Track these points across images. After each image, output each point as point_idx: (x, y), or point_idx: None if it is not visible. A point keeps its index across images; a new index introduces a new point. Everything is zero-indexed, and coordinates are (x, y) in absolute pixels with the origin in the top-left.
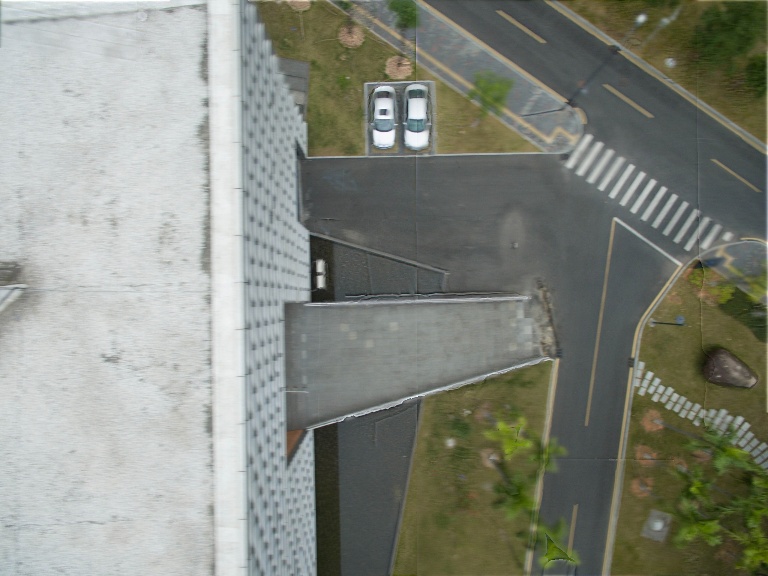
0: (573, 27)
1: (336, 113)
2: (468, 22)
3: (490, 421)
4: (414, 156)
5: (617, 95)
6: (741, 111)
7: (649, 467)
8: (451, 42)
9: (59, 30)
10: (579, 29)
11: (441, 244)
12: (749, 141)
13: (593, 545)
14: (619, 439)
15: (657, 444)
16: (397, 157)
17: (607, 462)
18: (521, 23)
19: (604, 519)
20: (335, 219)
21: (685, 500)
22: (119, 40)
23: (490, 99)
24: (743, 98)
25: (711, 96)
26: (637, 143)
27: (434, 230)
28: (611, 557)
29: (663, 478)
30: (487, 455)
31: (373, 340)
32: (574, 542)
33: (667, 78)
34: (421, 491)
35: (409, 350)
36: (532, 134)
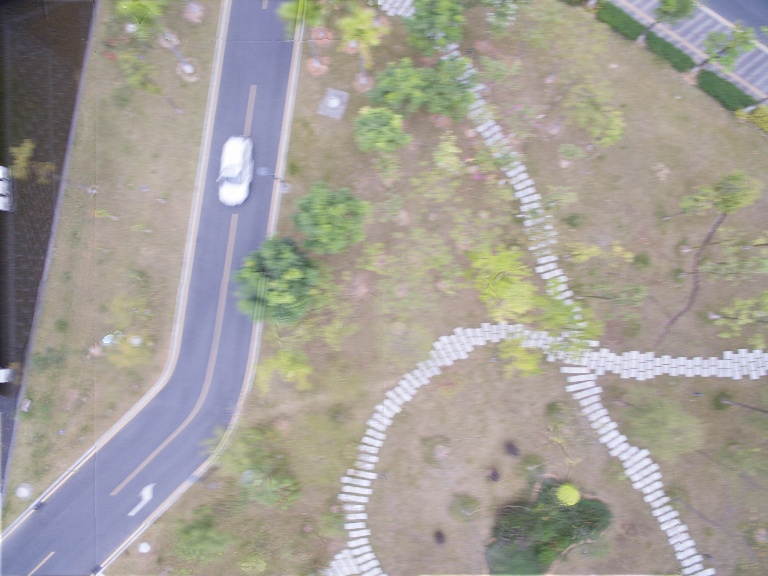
0: None
1: None
2: None
3: (166, 2)
4: None
5: None
6: None
7: (325, 47)
8: None
9: None
10: None
11: None
12: None
13: (270, 123)
14: (295, 20)
15: (333, 25)
16: None
17: (284, 43)
18: None
19: (281, 98)
20: None
21: (358, 76)
22: None
23: None
24: None
25: None
26: None
27: None
28: (287, 135)
29: (339, 58)
30: (162, 33)
31: None
32: (252, 123)
33: None
34: (100, 75)
35: None
36: None
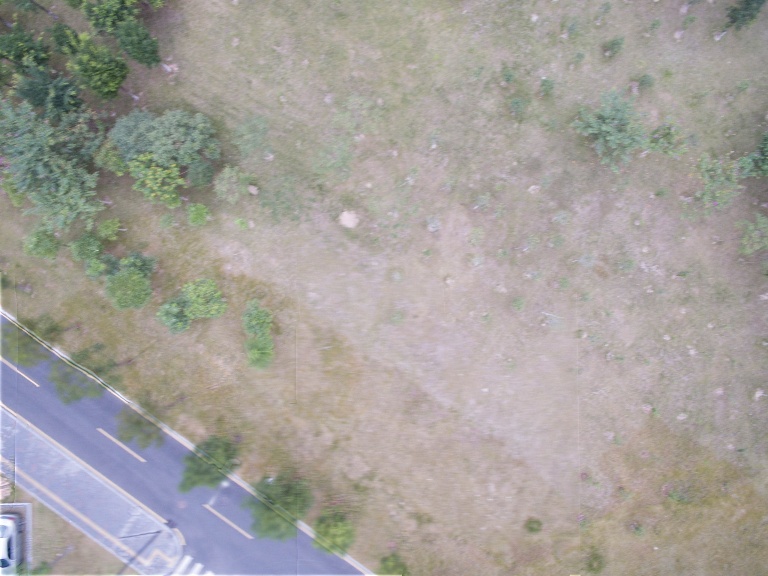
0: (174, 445)
1: None
2: (69, 440)
3: None
4: None
5: (217, 515)
6: (341, 532)
7: None
8: (51, 461)
9: None
10: (180, 447)
11: None
12: (350, 562)
13: None
14: None
15: None
16: None
17: None
18: (122, 441)
19: None
20: None
21: None
22: None
23: (88, 520)
24: (343, 519)
25: (311, 517)
26: (236, 565)
27: None
28: None
29: None
30: None
31: None
32: None
33: (267, 498)
34: None
35: None
36: (130, 557)
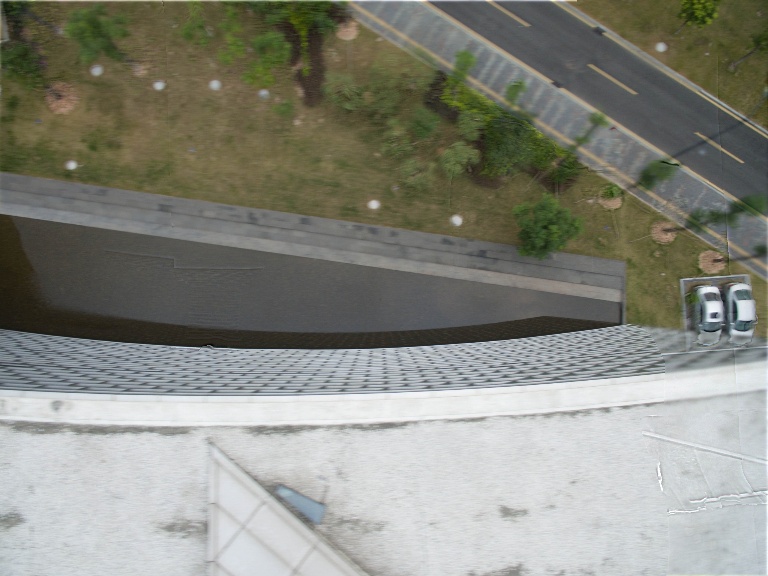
0: None
1: (654, 310)
2: None
3: None
4: (732, 349)
5: None
6: None
7: None
8: (761, 235)
9: (375, 238)
10: None
11: (763, 435)
12: None
13: None
14: None
15: None
16: (715, 351)
17: None
18: None
19: None
20: (659, 416)
21: None
22: (436, 246)
23: None
24: None
25: None
26: None
27: (756, 422)
28: None
29: None
30: None
31: (716, 541)
32: None
33: None
34: None
35: (749, 548)
36: None
